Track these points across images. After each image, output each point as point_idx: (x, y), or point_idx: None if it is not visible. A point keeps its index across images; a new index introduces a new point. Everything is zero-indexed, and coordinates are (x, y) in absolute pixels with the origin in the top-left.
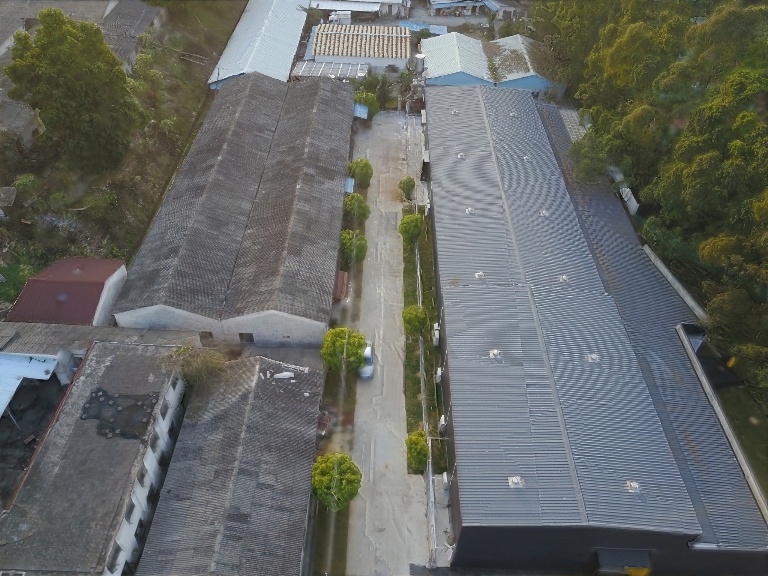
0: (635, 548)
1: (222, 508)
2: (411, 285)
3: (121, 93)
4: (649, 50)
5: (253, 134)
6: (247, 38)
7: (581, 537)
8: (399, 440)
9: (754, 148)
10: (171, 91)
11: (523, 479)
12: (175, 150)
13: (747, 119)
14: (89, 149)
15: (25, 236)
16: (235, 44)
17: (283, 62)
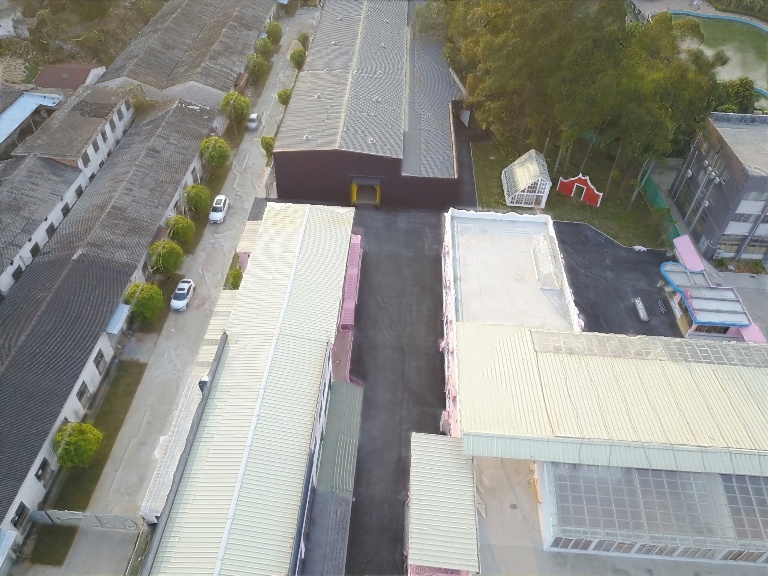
0: (373, 176)
1: (146, 147)
2: None
3: None
4: None
5: (201, 7)
6: None
7: (341, 166)
8: (264, 155)
9: None
10: None
11: (312, 137)
12: None
13: None
14: None
15: (42, 49)
16: None
17: None
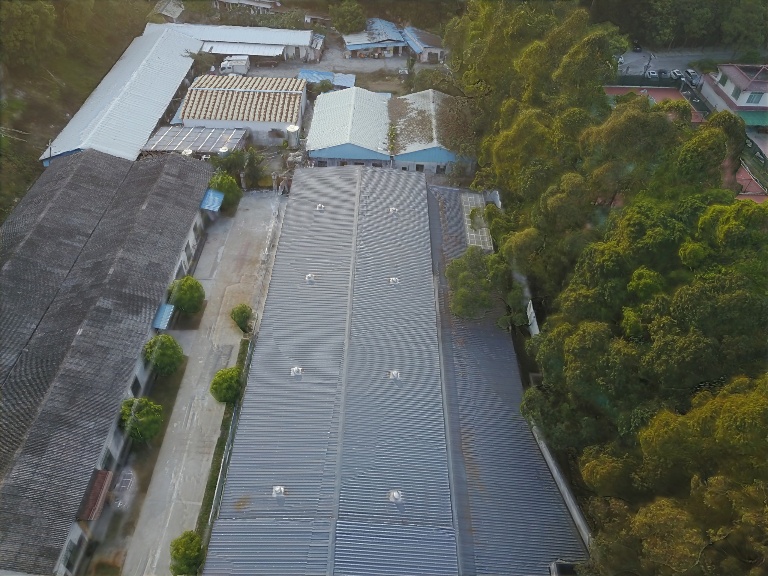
0: None
1: None
2: None
3: None
4: (540, 150)
5: (56, 242)
6: (106, 97)
7: None
8: None
9: (650, 330)
10: None
11: None
12: None
13: (644, 281)
14: None
15: None
16: (90, 104)
17: (141, 129)
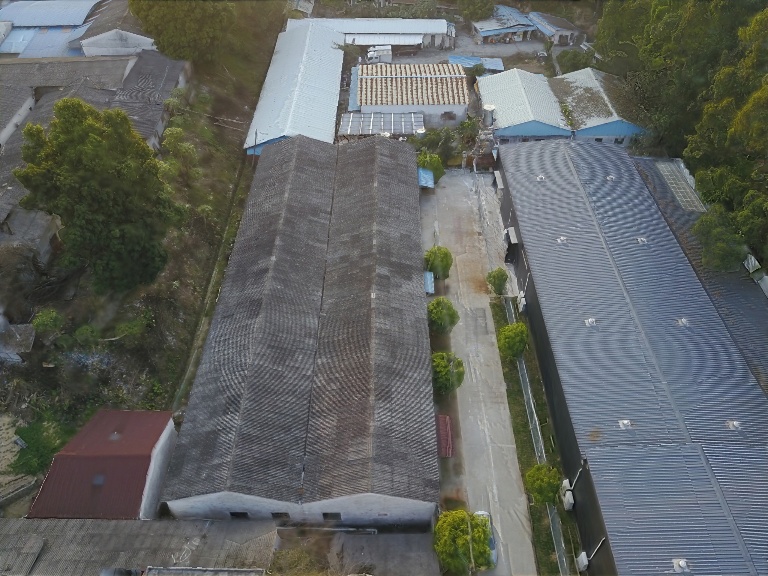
0: None
1: None
2: (520, 416)
3: (153, 187)
4: None
5: (307, 219)
6: (282, 88)
7: None
8: None
9: None
10: (204, 162)
11: None
12: (214, 237)
13: None
14: (120, 267)
15: (48, 385)
16: (269, 96)
17: (326, 116)
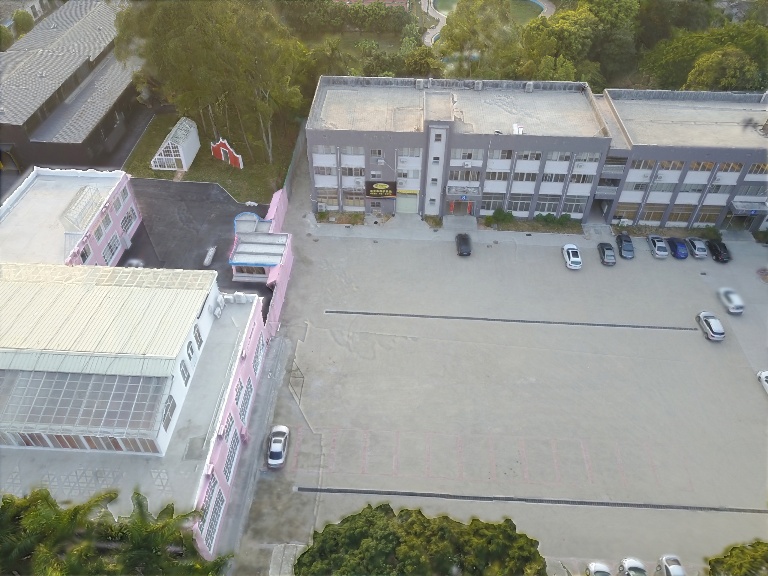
0: (4, 143)
1: None
2: None
3: None
4: None
5: None
6: None
7: None
8: None
9: None
10: None
11: None
12: None
13: None
14: None
15: None
16: None
17: None
